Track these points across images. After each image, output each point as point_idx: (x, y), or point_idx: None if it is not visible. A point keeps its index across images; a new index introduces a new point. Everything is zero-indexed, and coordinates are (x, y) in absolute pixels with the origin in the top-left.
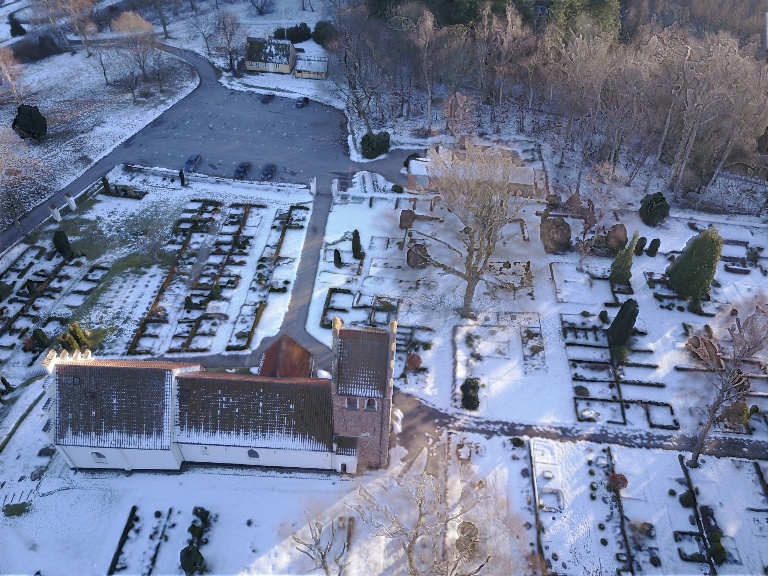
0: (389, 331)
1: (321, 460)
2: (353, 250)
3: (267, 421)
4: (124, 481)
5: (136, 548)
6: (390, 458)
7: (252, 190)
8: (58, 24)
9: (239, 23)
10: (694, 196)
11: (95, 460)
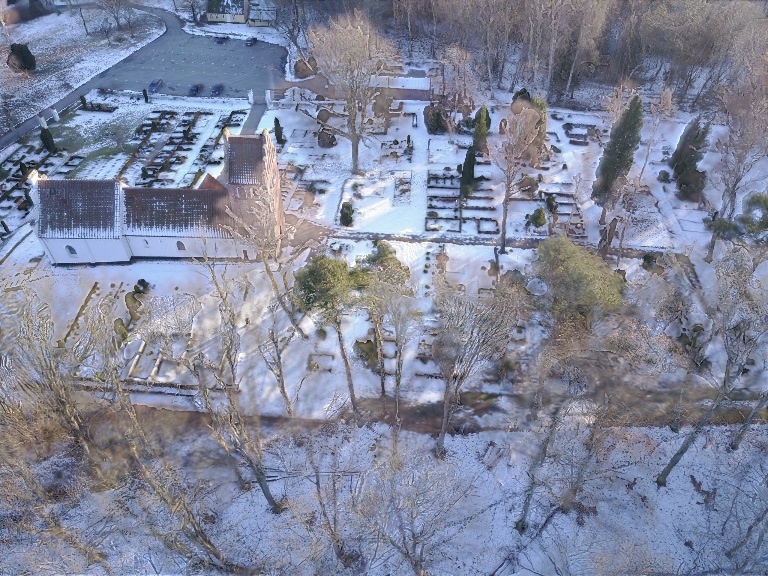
0: None
1: (229, 249)
2: (276, 136)
3: (188, 218)
4: (90, 270)
5: None
6: (282, 253)
7: (202, 103)
8: None
9: None
10: (567, 100)
11: (69, 255)
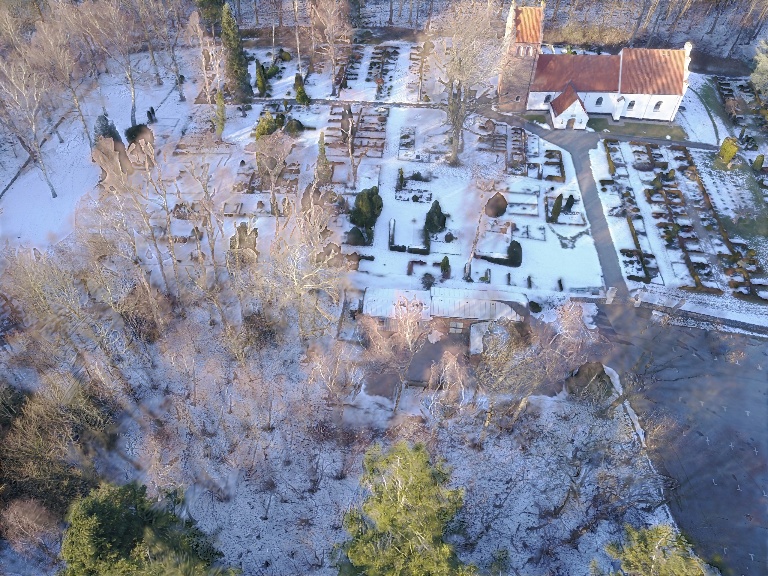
0: None
1: None
2: None
3: None
4: None
5: None
6: None
7: None
8: None
9: None
10: None
11: None
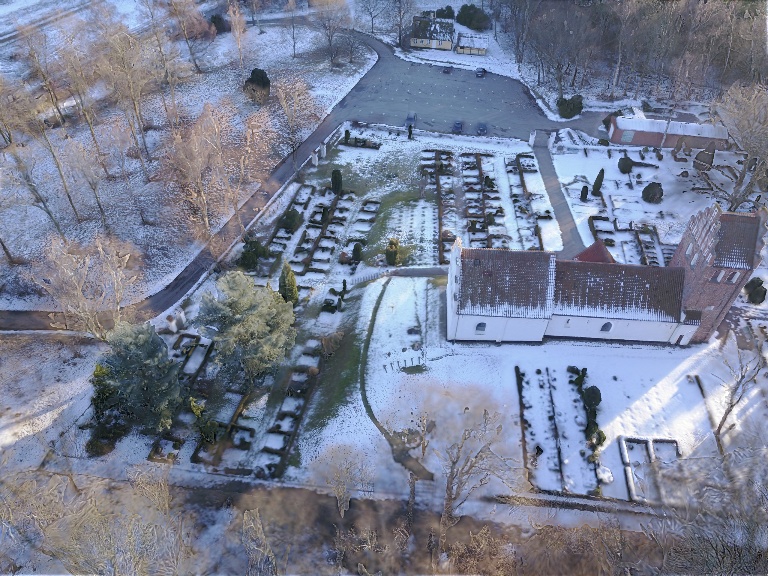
0: (760, 215)
1: (662, 333)
2: (595, 188)
3: (626, 298)
4: (497, 350)
5: (532, 394)
6: None
7: (473, 143)
8: (236, 3)
9: (412, 2)
10: None
11: (475, 332)
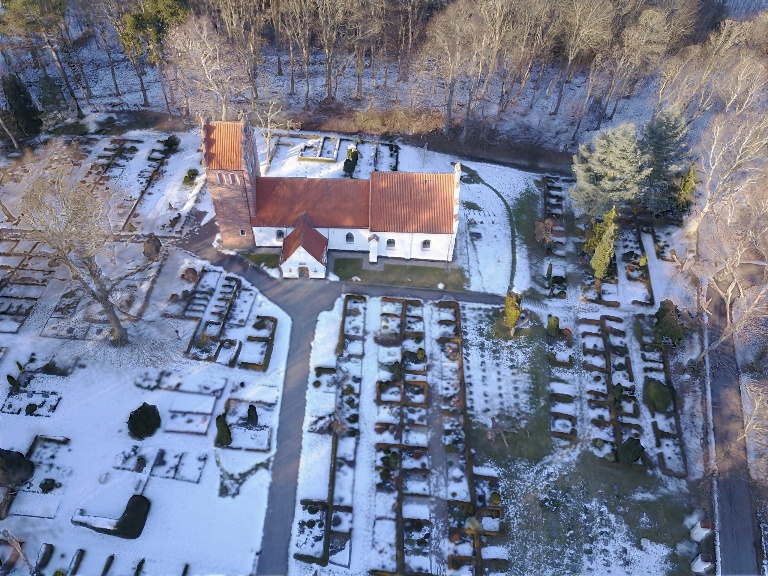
0: None
1: None
2: None
3: None
4: None
5: None
6: None
7: None
8: None
9: None
10: None
11: None
